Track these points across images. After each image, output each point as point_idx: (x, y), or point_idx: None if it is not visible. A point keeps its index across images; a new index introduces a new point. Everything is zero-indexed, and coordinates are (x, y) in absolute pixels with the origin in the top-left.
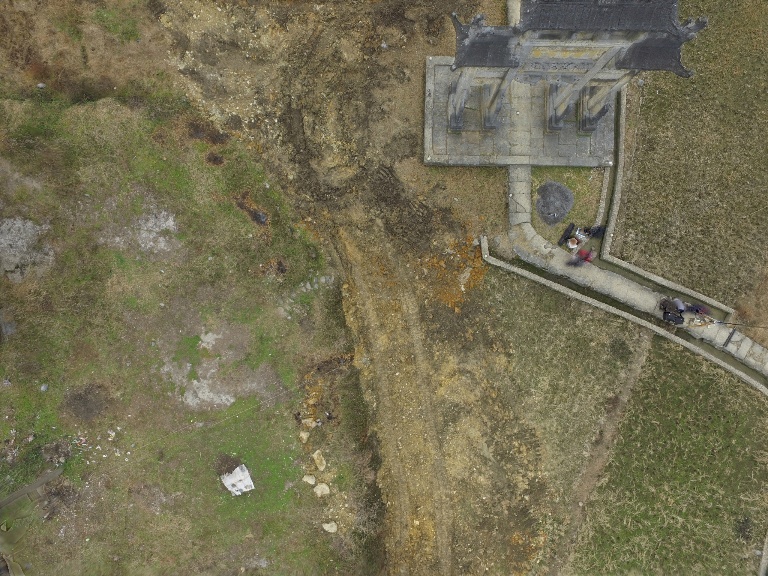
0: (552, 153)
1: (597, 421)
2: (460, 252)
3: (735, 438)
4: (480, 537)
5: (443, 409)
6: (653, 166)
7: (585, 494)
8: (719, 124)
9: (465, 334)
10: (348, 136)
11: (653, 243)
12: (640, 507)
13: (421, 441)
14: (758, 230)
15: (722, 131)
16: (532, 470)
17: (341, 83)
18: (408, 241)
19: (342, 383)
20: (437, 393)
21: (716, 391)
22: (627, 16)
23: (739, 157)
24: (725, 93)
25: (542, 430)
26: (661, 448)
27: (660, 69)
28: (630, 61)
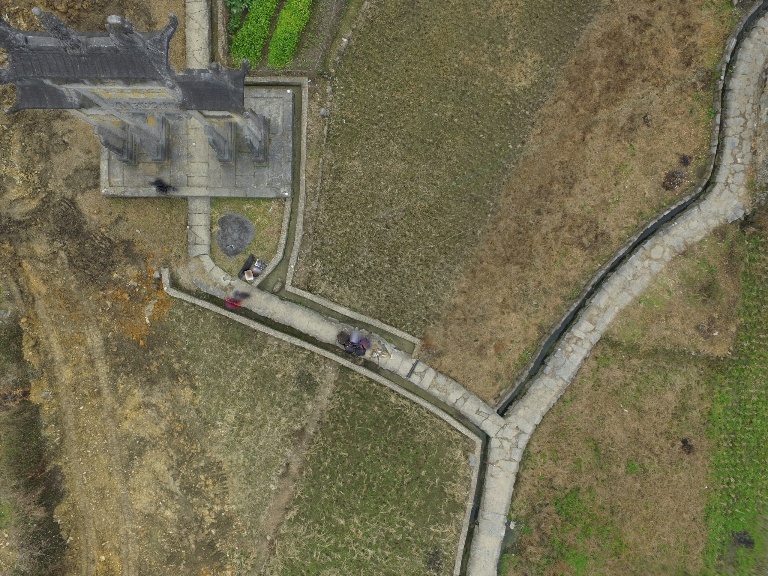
0: (229, 184)
1: (284, 453)
2: (145, 284)
3: (425, 469)
4: (167, 572)
5: (128, 443)
6: (340, 196)
7: (272, 527)
8: (406, 153)
9: (150, 367)
10: (30, 168)
11: (341, 273)
12: (330, 540)
13: (106, 475)
14: (446, 259)
15: (408, 160)
16: (219, 504)
17: (24, 114)
18: (90, 274)
19: (8, 419)
20: (122, 427)
21: (405, 422)
22: (110, 64)
23: (427, 186)
24: (412, 122)
25: (229, 463)
26: (351, 480)
27: (223, 110)
28: (190, 102)
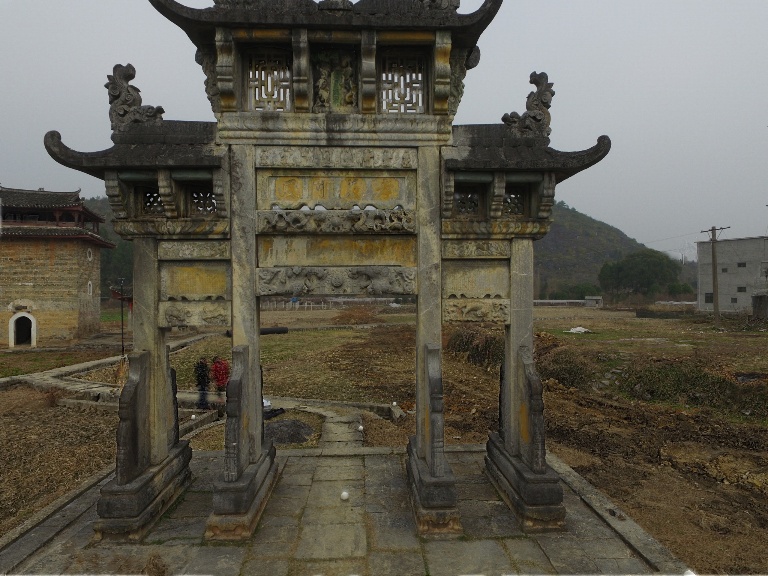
0: None
1: None
2: None
3: None
4: None
5: None
6: None
7: None
8: None
9: None
10: None
11: None
12: None
13: None
14: None
15: None
16: None
17: None
18: None
19: None
20: None
21: None
22: None
23: None
24: None
25: None
26: None
27: None
28: None
